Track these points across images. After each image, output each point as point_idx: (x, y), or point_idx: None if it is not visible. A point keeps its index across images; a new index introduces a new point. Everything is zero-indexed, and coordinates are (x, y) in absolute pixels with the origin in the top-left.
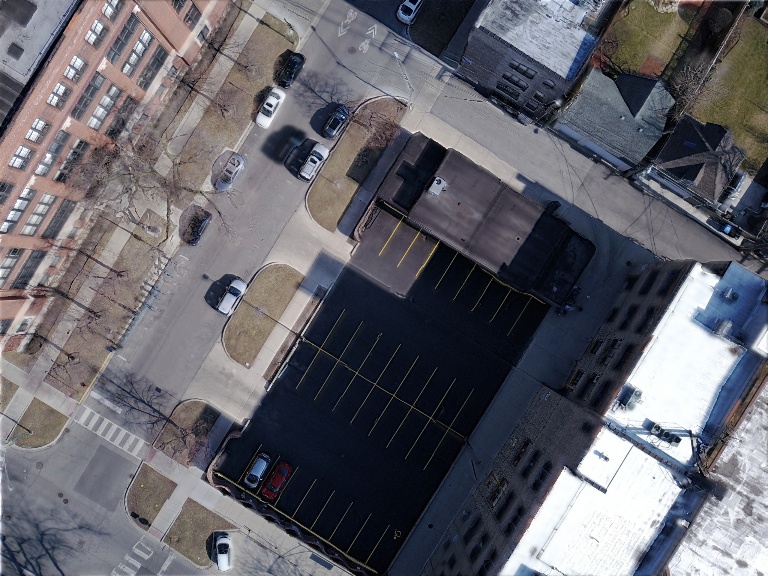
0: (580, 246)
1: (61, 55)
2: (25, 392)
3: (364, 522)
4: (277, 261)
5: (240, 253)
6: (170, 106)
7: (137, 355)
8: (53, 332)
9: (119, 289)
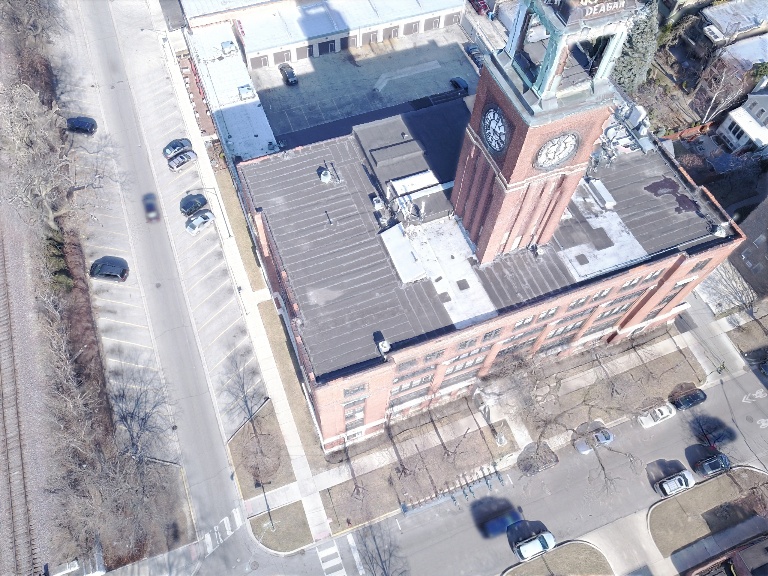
0: None
1: (613, 281)
2: (297, 489)
3: None
4: (595, 545)
5: (564, 512)
6: (573, 359)
7: (413, 532)
8: (359, 458)
9: (438, 464)
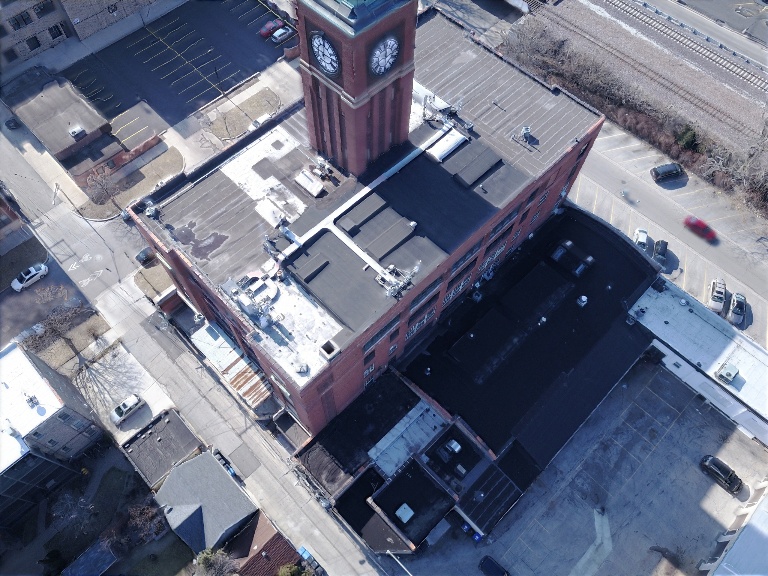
0: (6, 91)
1: None
2: None
3: (227, 1)
4: None
5: None
6: None
7: None
8: None
9: None
